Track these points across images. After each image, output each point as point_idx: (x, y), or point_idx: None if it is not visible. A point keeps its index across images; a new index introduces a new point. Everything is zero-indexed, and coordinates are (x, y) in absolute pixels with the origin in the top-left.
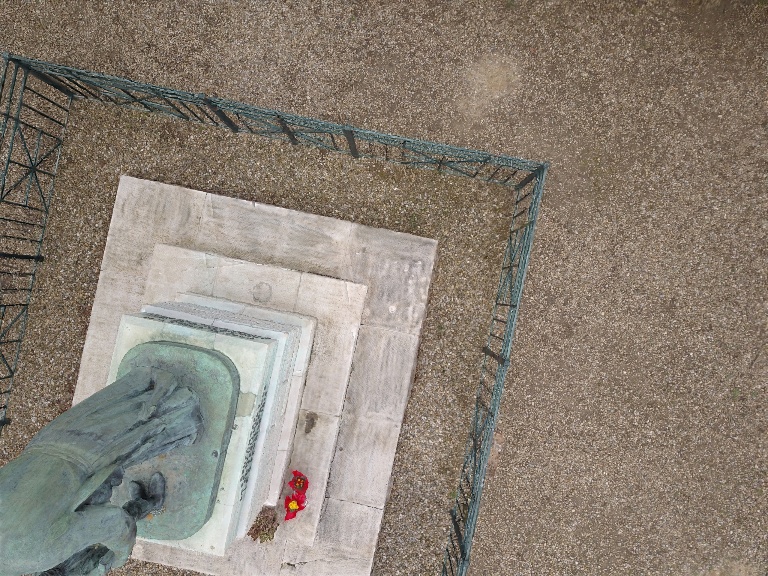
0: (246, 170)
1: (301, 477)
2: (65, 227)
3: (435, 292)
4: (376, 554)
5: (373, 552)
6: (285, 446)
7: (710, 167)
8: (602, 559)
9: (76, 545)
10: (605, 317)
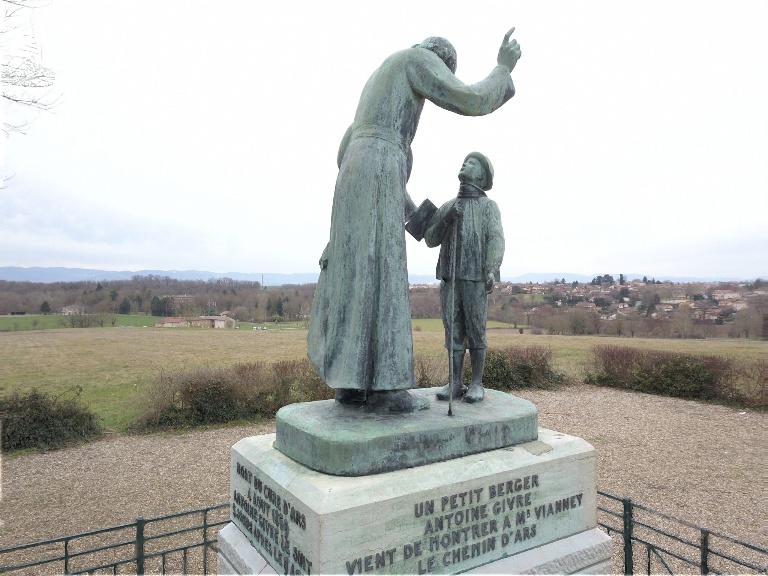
0: None
1: None
2: None
3: None
4: None
5: None
6: None
7: None
8: None
9: None
10: None
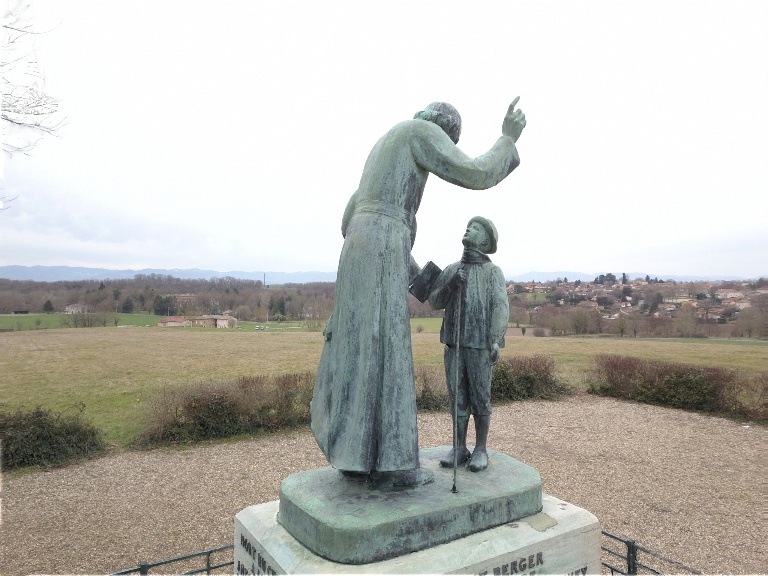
0: None
1: None
2: None
3: None
4: None
5: None
6: None
7: None
8: None
9: None
10: None
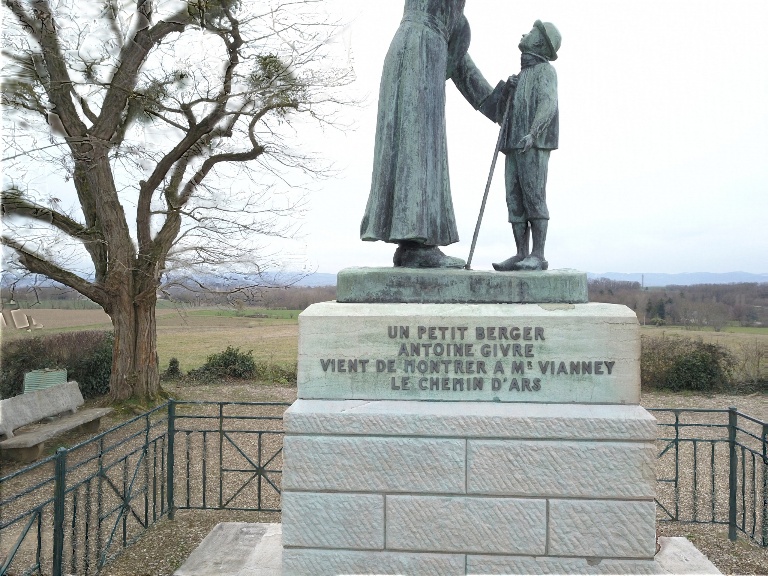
0: None
1: None
2: None
3: None
4: None
5: None
6: None
7: None
8: None
9: None
10: None
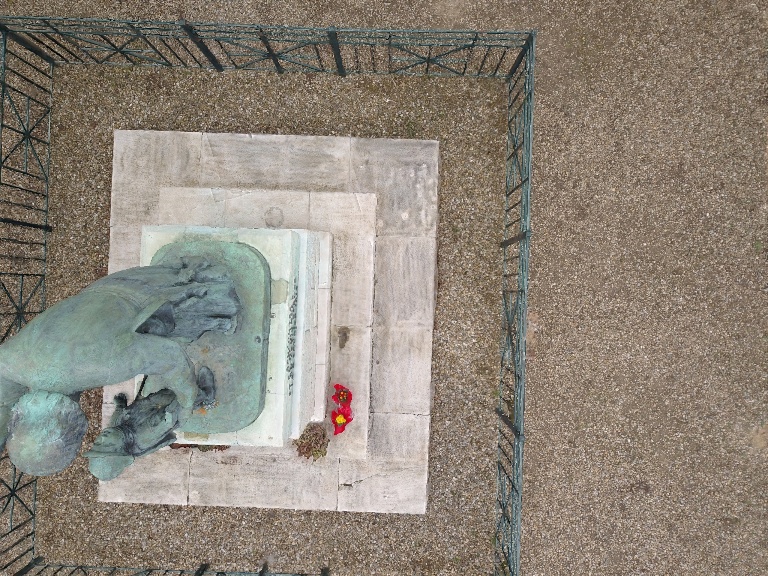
0: (237, 107)
1: (343, 390)
2: (68, 194)
3: (444, 196)
4: (429, 464)
5: (426, 459)
6: (322, 360)
7: (695, 27)
8: (653, 432)
9: (143, 360)
10: (616, 193)
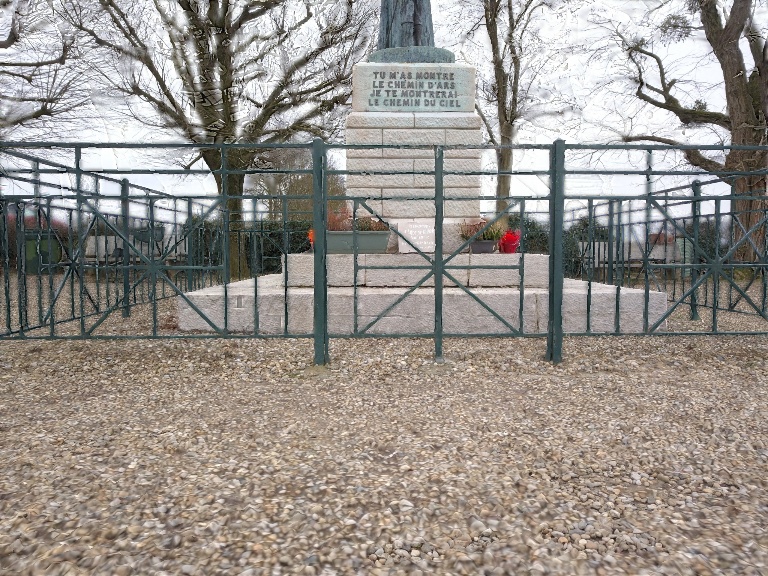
0: None
1: None
2: None
3: None
4: None
5: None
6: None
7: None
8: None
9: None
10: None
